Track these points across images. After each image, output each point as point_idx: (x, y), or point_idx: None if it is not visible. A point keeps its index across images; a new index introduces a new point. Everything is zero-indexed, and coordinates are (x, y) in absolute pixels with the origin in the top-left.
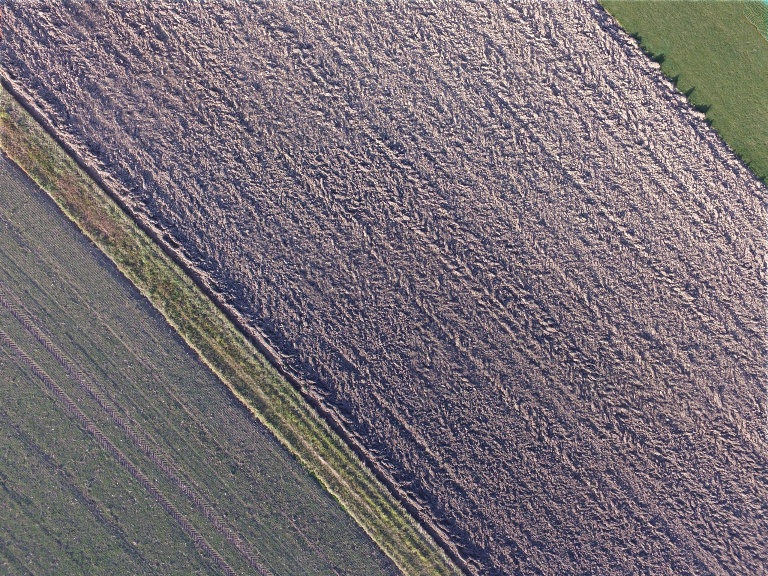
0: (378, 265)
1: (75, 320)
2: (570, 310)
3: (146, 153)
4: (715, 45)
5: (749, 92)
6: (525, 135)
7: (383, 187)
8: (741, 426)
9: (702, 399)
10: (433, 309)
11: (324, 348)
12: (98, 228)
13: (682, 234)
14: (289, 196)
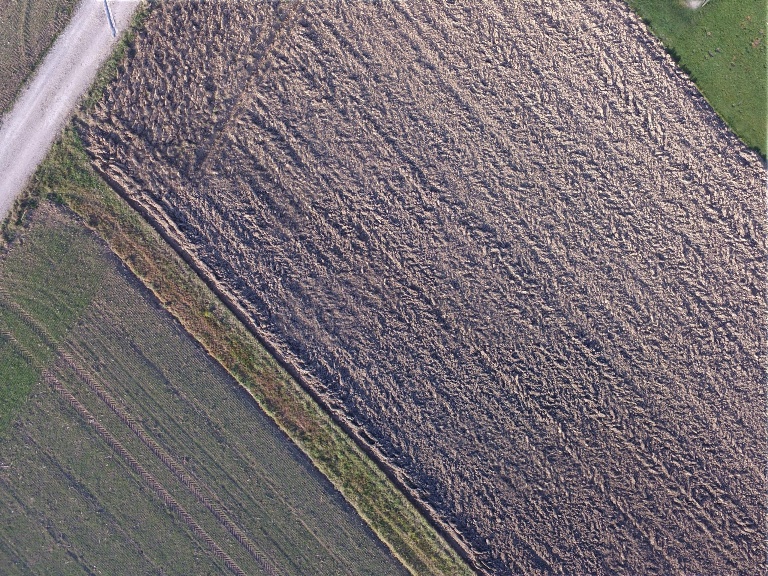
0: (572, 462)
1: (270, 515)
2: None
3: (345, 351)
4: None
5: None
6: (723, 334)
7: (579, 384)
8: None
9: None
10: (628, 507)
11: (517, 544)
12: (295, 424)
13: None
14: (484, 392)
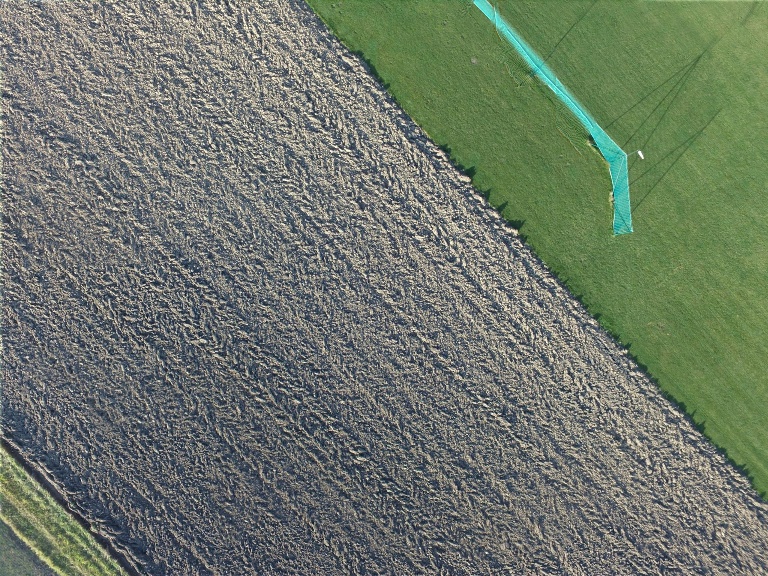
0: (173, 392)
1: None
2: (382, 437)
3: None
4: (527, 158)
5: (564, 207)
6: (331, 251)
7: (177, 308)
8: (563, 559)
9: (522, 530)
10: (234, 438)
11: (115, 482)
12: None
13: (498, 356)
14: (74, 318)
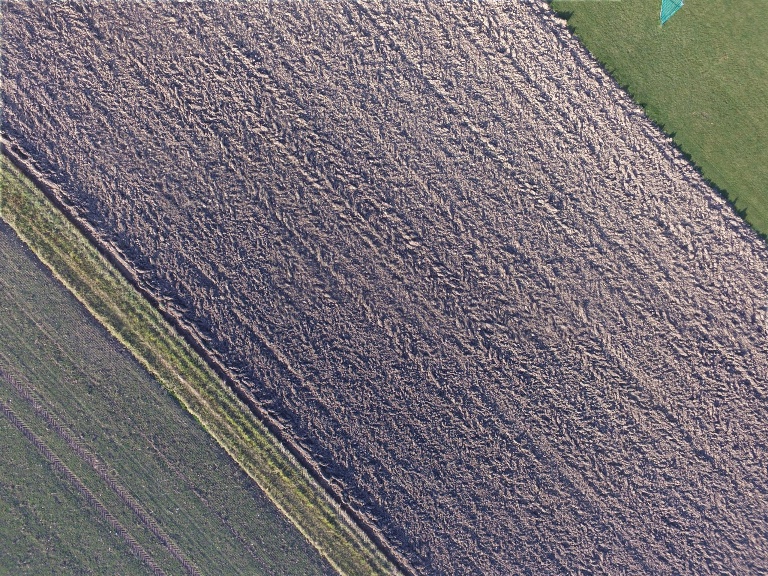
0: (236, 178)
1: None
2: (433, 223)
3: None
4: None
5: None
6: (385, 43)
7: (240, 97)
8: (606, 340)
9: (567, 313)
10: (293, 223)
11: (182, 264)
12: None
13: (545, 145)
14: (143, 106)
